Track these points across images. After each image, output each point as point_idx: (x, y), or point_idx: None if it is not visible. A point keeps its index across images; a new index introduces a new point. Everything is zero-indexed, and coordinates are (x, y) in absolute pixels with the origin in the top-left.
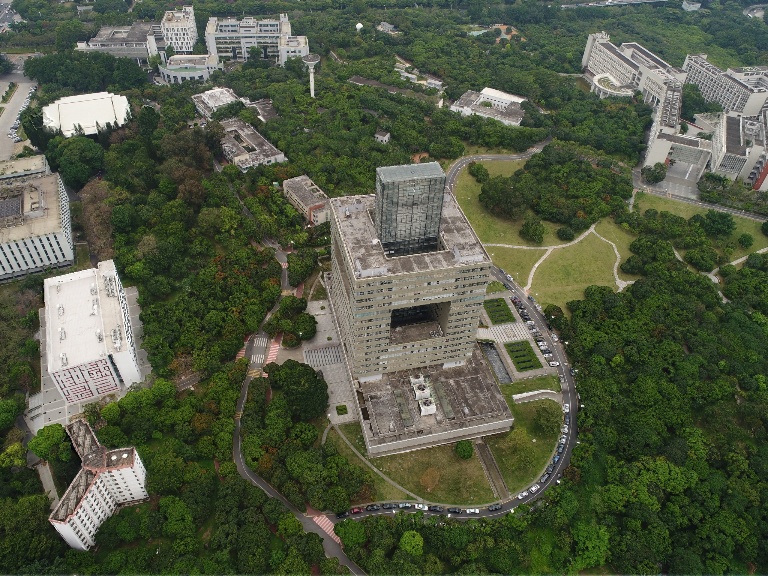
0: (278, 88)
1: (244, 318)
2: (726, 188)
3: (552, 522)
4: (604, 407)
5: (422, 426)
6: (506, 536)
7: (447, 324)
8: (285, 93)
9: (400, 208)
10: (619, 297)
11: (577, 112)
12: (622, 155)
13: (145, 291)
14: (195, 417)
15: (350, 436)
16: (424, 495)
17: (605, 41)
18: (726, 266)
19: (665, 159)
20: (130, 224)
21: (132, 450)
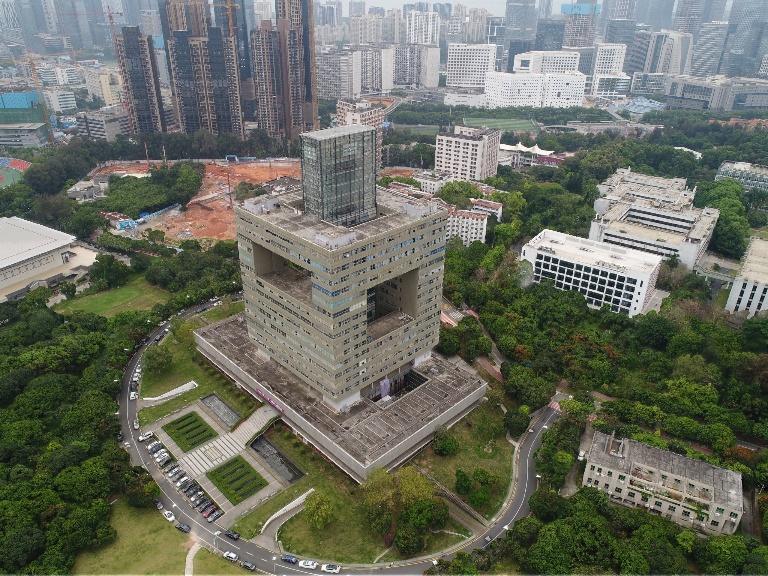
0: None
1: None
2: None
3: None
4: None
5: None
6: None
7: None
8: None
9: None
10: (5, 561)
11: None
12: None
13: None
14: None
15: None
16: None
17: None
18: None
19: None
20: (748, 339)
21: None
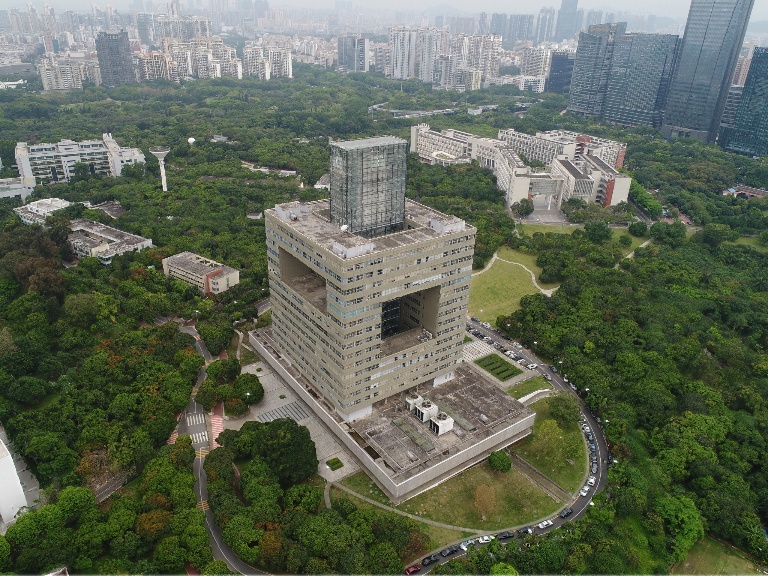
0: (123, 188)
1: (166, 394)
2: (586, 208)
3: (634, 505)
4: (606, 387)
5: (445, 446)
6: (600, 535)
7: (437, 319)
8: (133, 191)
9: (365, 185)
10: (556, 297)
11: (433, 176)
12: (487, 201)
13: (5, 401)
14: (141, 518)
15: (359, 489)
16: (482, 526)
17: (427, 130)
18: (624, 259)
19: (527, 195)
20: None
21: (63, 573)
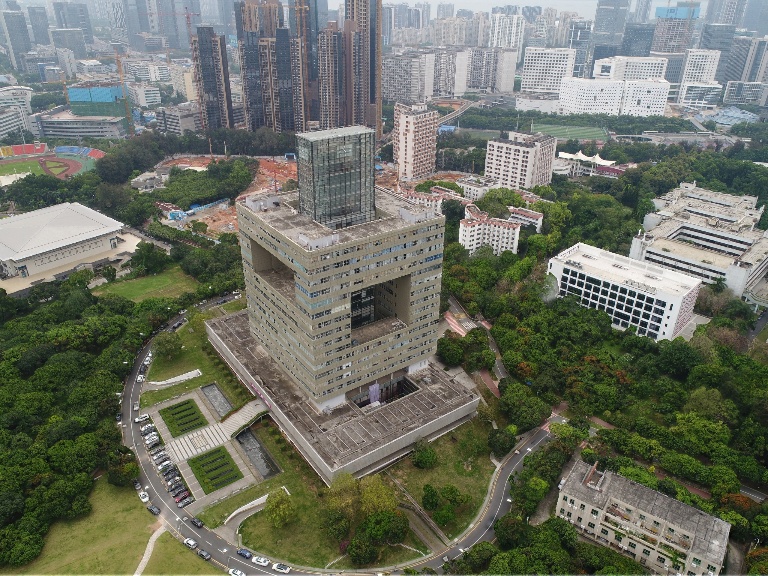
0: None
1: None
2: None
3: None
4: None
5: None
6: None
7: None
8: None
9: None
10: None
11: None
12: None
13: None
14: None
15: None
16: None
17: None
18: None
19: None
20: None
21: None
